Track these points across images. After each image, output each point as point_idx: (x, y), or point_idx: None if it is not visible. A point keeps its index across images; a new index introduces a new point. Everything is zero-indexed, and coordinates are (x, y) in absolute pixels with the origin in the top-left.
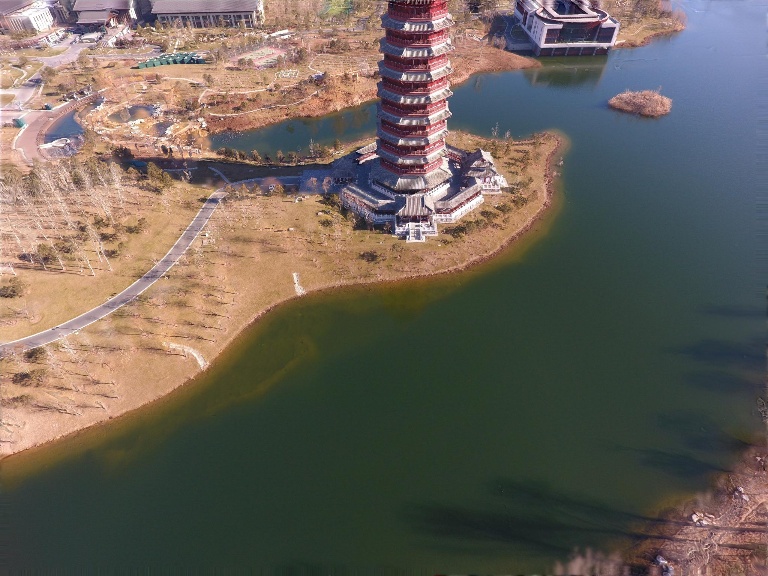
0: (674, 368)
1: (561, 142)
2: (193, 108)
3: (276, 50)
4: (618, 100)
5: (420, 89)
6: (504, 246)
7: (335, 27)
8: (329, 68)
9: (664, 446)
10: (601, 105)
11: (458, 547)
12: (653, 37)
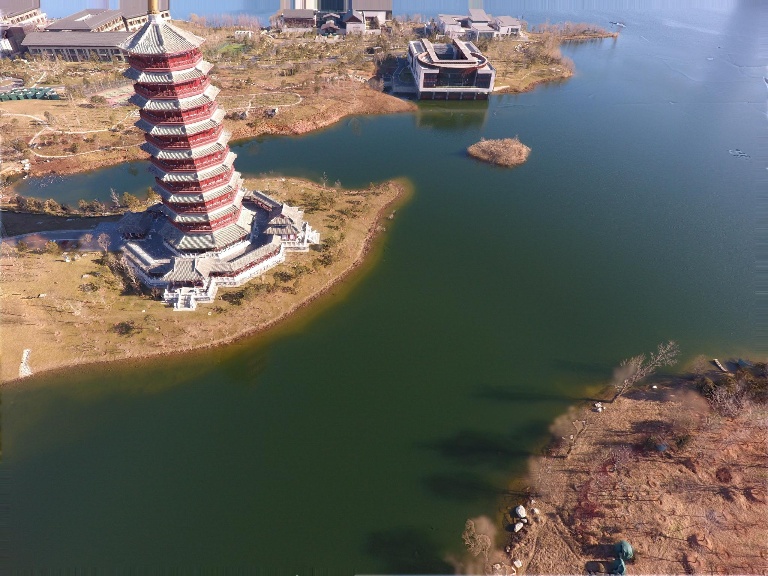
0: (417, 469)
1: (402, 192)
2: (20, 148)
3: None
4: (476, 148)
5: (179, 143)
6: (288, 314)
7: (215, 65)
8: None
9: None
10: (460, 152)
11: None
12: (539, 83)
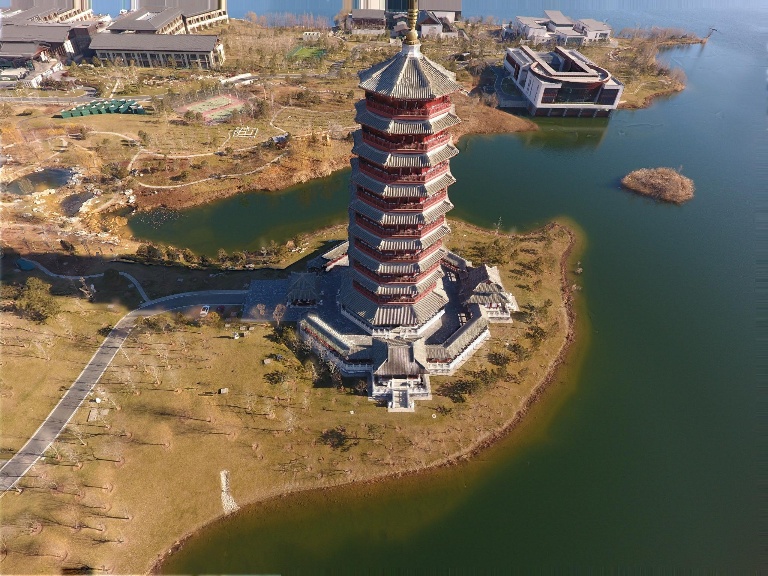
0: None
1: (575, 237)
2: (120, 176)
3: (234, 99)
4: (633, 180)
5: (410, 205)
6: (522, 413)
7: (304, 74)
8: (295, 126)
9: None
10: (613, 184)
11: None
12: (654, 97)
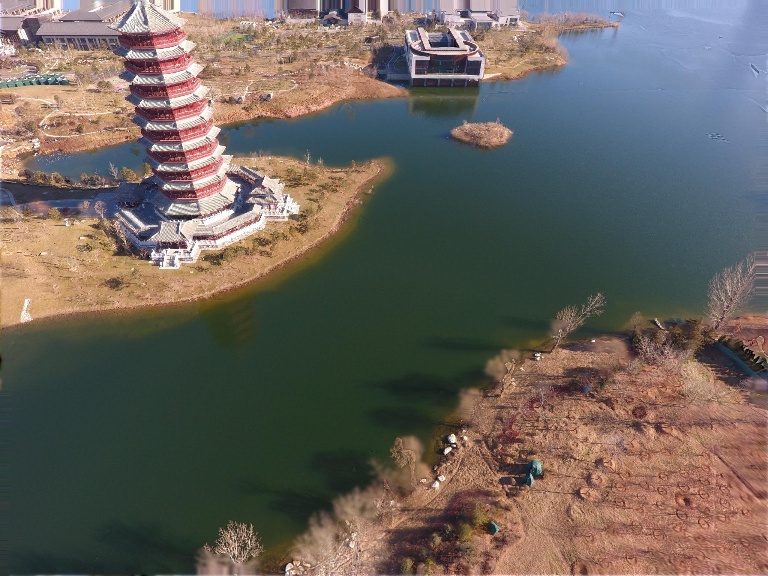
0: (365, 403)
1: (383, 170)
2: (31, 129)
3: None
4: (459, 130)
5: (165, 116)
6: (263, 274)
7: (217, 53)
8: None
9: (304, 487)
10: (444, 135)
11: None
12: (531, 71)
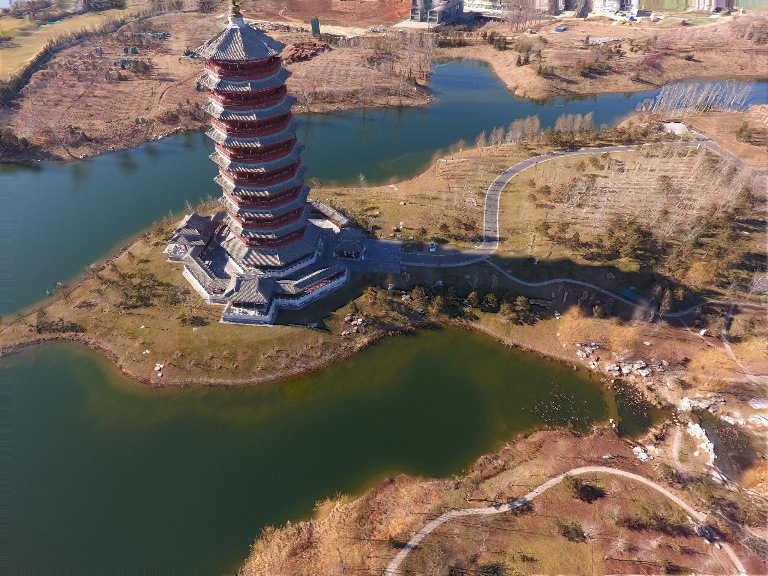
0: None
1: None
2: None
3: None
4: None
5: None
6: None
7: None
8: None
9: None
10: None
11: None
12: None
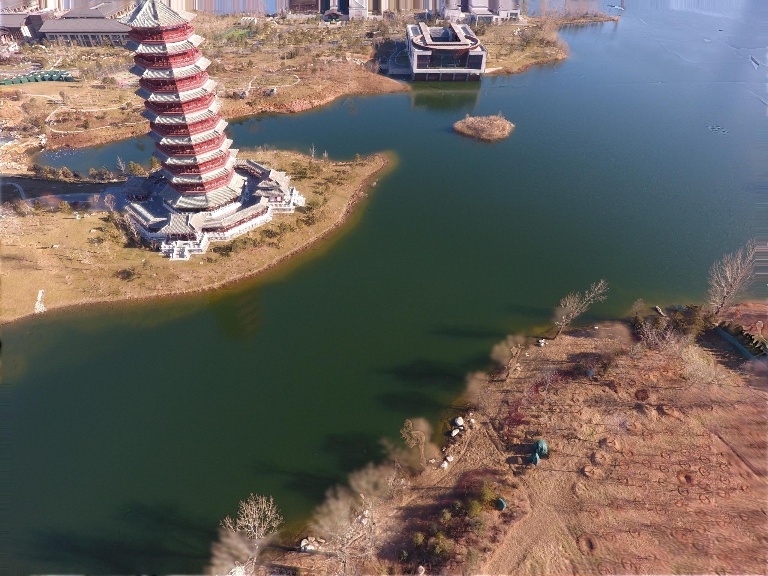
0: (374, 388)
1: (387, 164)
2: (37, 125)
3: None
4: (461, 124)
5: (174, 109)
6: (271, 265)
7: (219, 49)
8: None
9: (317, 468)
10: (447, 128)
11: (45, 575)
12: (532, 65)
